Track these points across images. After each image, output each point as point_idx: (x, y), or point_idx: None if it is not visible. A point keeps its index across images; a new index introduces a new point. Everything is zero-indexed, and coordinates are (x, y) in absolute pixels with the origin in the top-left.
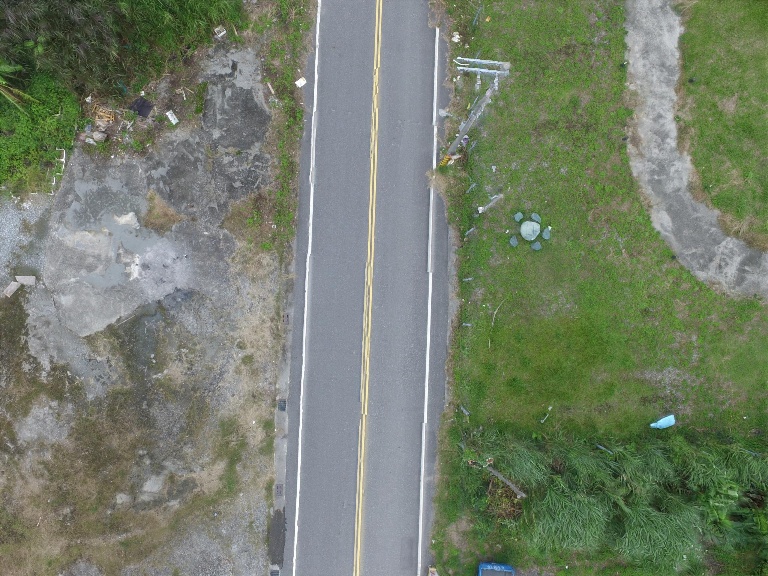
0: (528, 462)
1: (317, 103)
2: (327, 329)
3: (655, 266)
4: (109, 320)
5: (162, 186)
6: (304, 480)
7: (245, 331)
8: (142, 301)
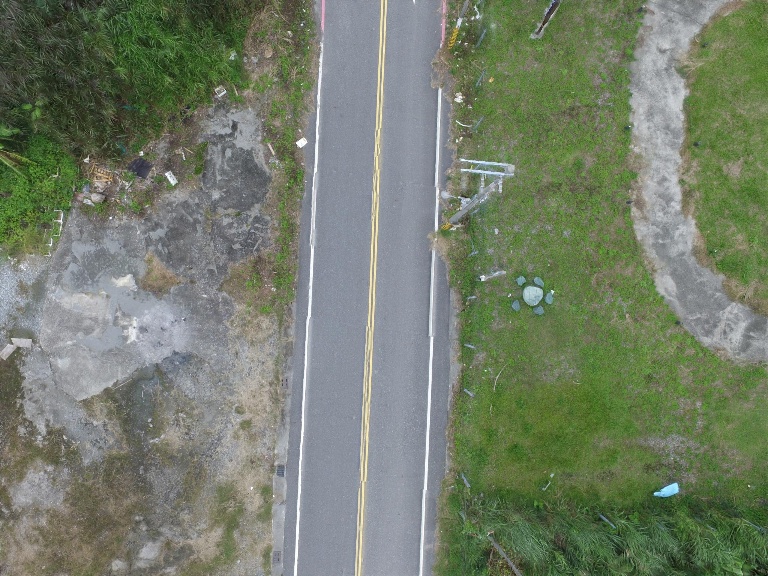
0: (530, 538)
1: (318, 164)
2: (327, 394)
3: (659, 331)
4: (106, 384)
5: (161, 248)
6: (302, 547)
7: (243, 395)
8: (139, 364)
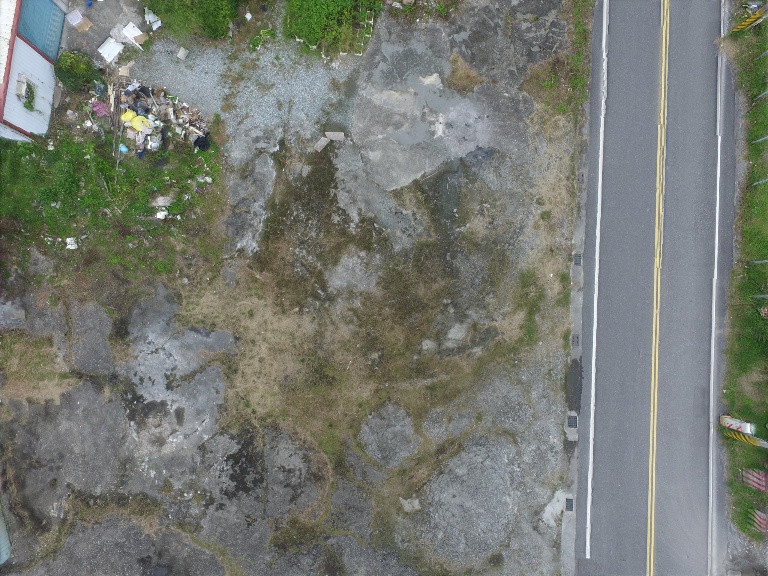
0: None
1: None
2: (621, 188)
3: None
4: (414, 175)
5: (464, 49)
6: (600, 331)
7: (543, 188)
8: (445, 158)
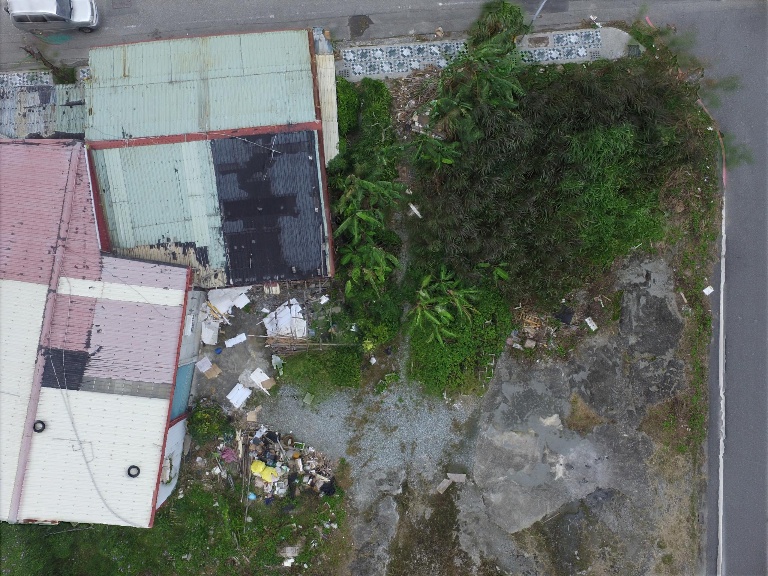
0: None
1: (723, 310)
2: (741, 530)
3: None
4: (536, 518)
5: (583, 389)
6: None
7: (664, 531)
8: (566, 500)
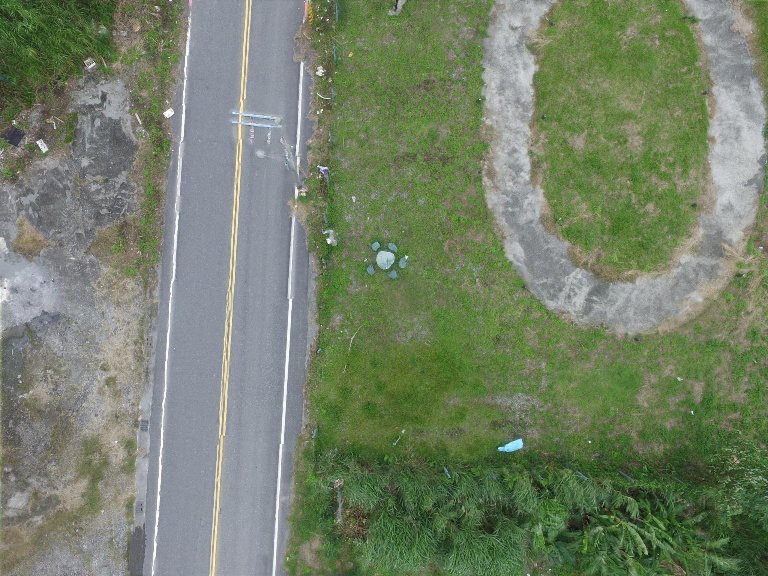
0: (365, 485)
1: (184, 133)
2: (189, 352)
3: (507, 295)
4: None
5: (31, 212)
6: (164, 498)
7: (109, 354)
8: (10, 323)
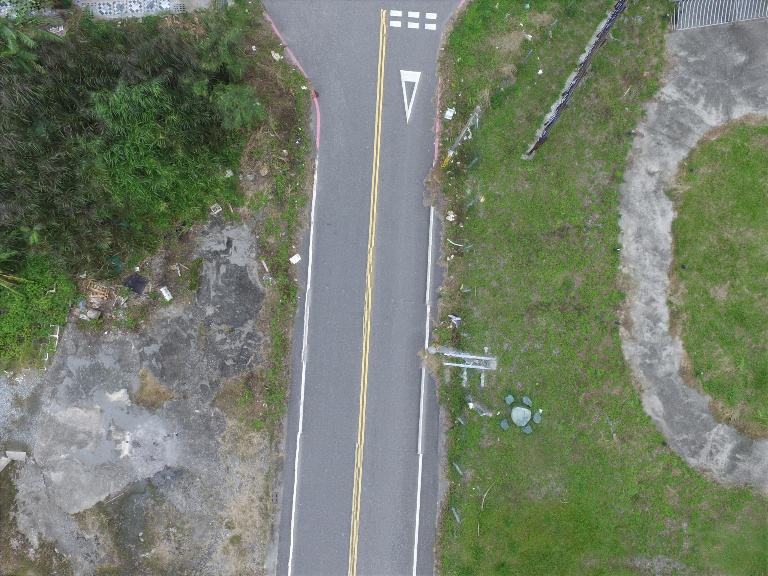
0: None
1: (311, 280)
2: (316, 510)
3: (646, 452)
4: (98, 498)
5: (154, 363)
6: None
7: (234, 511)
8: (132, 479)
